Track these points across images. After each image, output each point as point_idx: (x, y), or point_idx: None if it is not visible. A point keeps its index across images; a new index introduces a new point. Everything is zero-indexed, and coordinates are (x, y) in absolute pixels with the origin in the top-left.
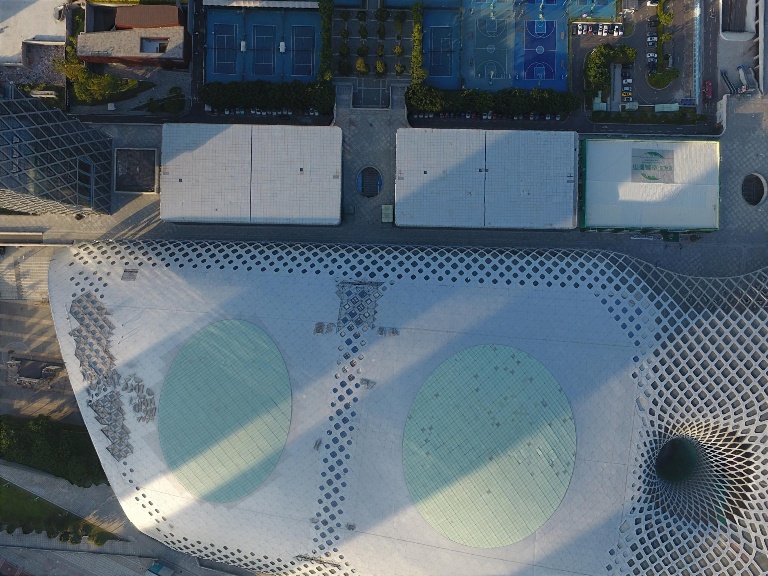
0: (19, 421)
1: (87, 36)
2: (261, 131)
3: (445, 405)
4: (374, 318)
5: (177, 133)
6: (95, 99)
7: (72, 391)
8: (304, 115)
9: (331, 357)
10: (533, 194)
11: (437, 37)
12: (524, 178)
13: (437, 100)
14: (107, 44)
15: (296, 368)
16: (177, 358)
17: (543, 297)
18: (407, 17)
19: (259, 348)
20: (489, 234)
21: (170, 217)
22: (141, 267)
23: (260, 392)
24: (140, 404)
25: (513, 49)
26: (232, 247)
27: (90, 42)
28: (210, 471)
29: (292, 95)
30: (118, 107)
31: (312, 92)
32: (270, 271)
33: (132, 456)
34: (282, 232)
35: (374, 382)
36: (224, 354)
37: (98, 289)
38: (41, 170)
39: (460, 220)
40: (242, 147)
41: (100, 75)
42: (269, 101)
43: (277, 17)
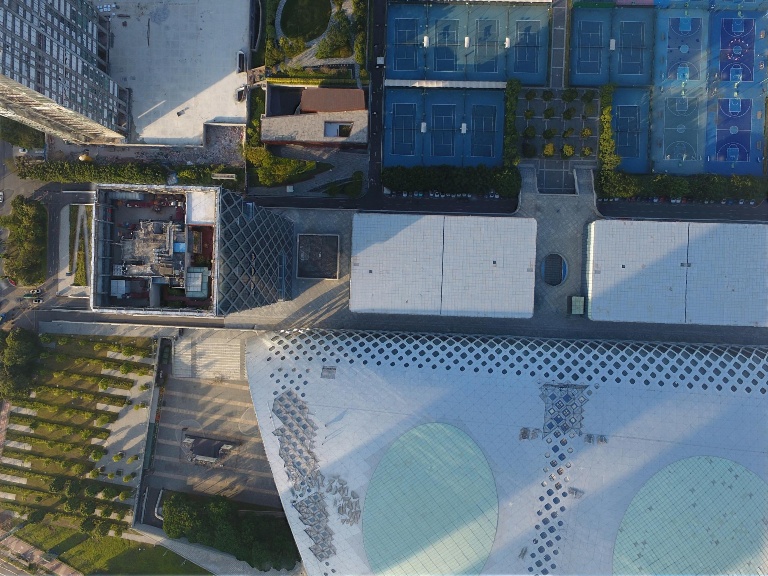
0: (197, 501)
1: (271, 120)
2: (453, 222)
3: (660, 519)
4: (581, 424)
5: (368, 223)
6: (275, 182)
7: (243, 469)
8: (484, 198)
9: (537, 464)
10: (738, 290)
11: (624, 117)
12: (729, 274)
13: (631, 187)
14: (291, 128)
15: (502, 475)
16: (382, 461)
17: (758, 405)
18: (593, 96)
19: (465, 453)
20: (680, 326)
21: (360, 309)
22: (339, 364)
23: (466, 499)
24: (344, 506)
25: (705, 129)
26: (426, 343)
27: (274, 126)
28: (414, 575)
29: (479, 181)
30: (295, 189)
31: (500, 178)
32: (470, 371)
33: (335, 557)
34: (464, 320)
35: (582, 491)
36: (430, 459)
37: (299, 387)
38: (264, 279)
39: (659, 316)
40: (434, 238)
41: (279, 157)
42: (455, 187)
43: (458, 96)
